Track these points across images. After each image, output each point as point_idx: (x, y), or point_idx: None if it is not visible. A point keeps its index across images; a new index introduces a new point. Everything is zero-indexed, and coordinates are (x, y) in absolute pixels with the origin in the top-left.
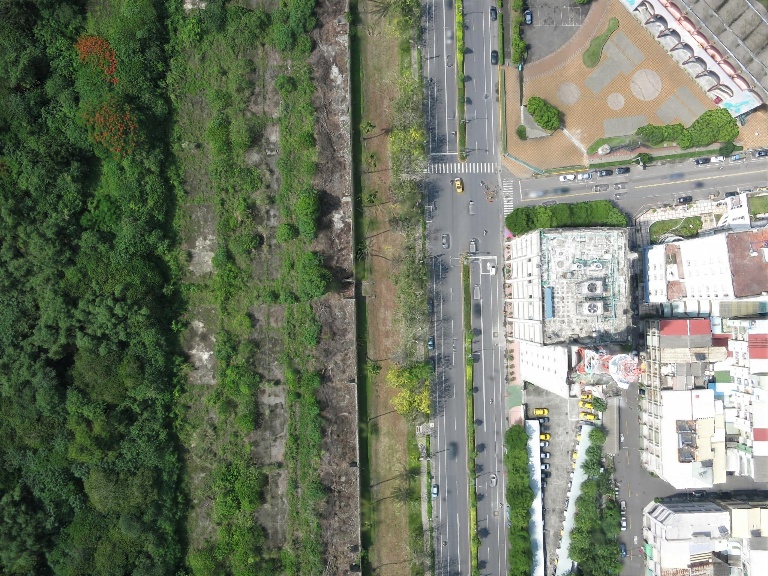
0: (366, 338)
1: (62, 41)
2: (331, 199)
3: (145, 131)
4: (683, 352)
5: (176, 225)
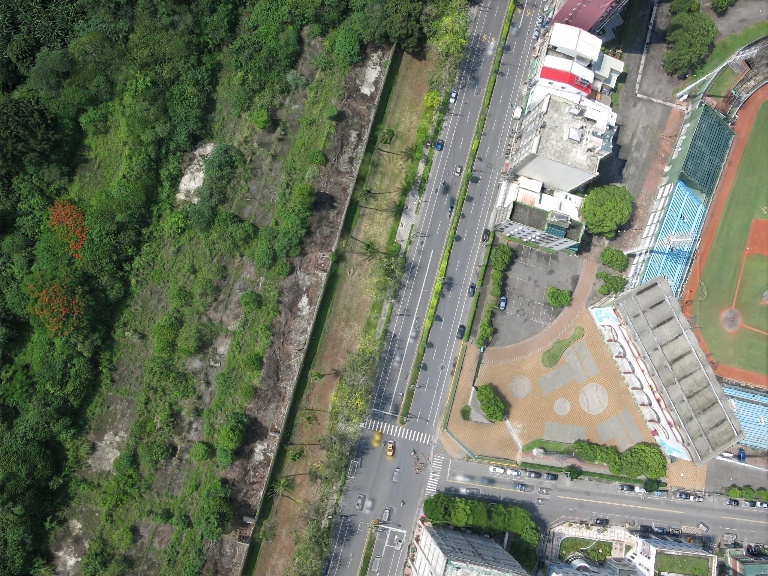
0: None
1: (38, 200)
2: (259, 428)
3: (90, 317)
4: None
5: (90, 412)
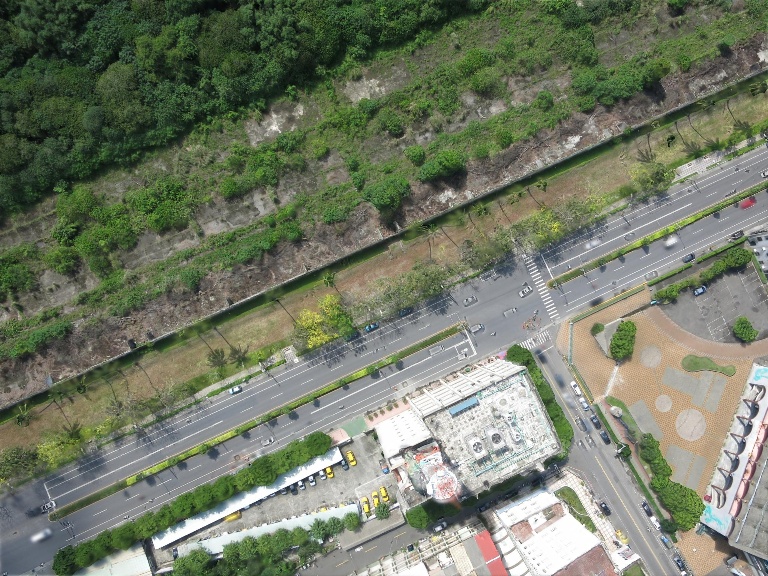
0: (351, 265)
1: None
2: (463, 182)
3: None
4: (468, 565)
5: (381, 55)
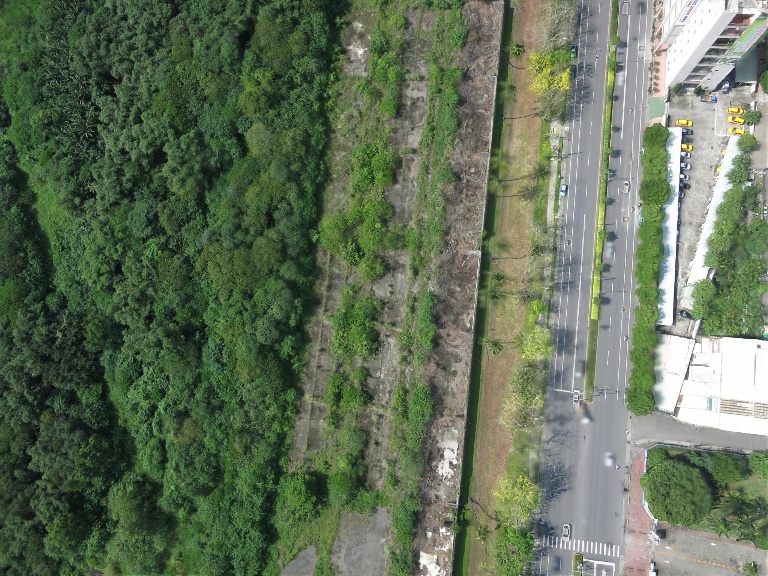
0: (510, 45)
1: None
2: None
3: None
4: None
5: None
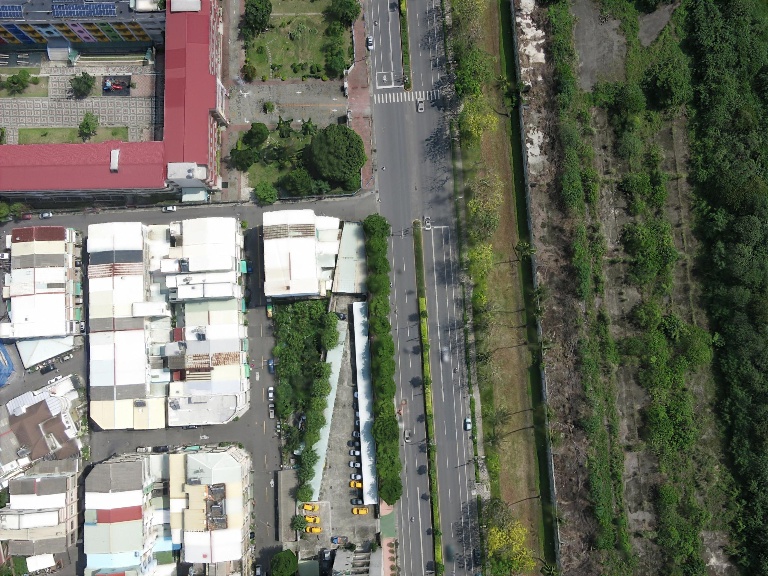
0: None
1: None
2: None
3: None
4: None
5: None
